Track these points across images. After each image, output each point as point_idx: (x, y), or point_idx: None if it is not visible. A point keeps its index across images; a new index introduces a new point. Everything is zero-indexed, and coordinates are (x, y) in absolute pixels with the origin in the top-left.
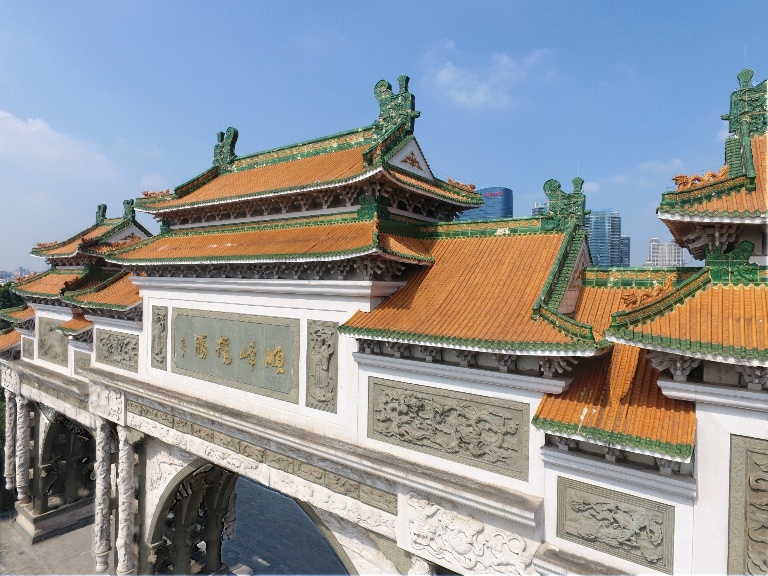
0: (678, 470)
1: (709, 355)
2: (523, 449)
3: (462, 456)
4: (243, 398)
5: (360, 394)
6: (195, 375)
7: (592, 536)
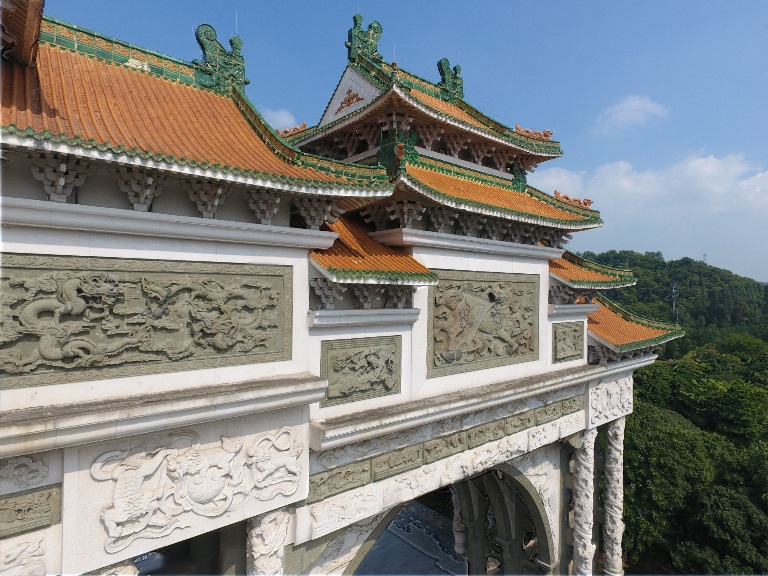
0: None
1: (446, 200)
2: (285, 322)
3: (200, 358)
4: None
5: None
6: None
7: (353, 388)
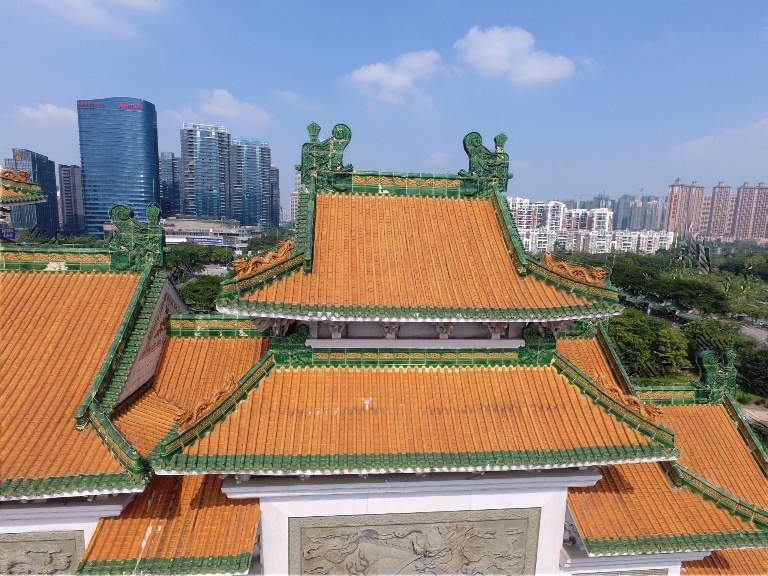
0: None
1: (261, 471)
2: None
3: None
4: None
5: None
6: None
7: None
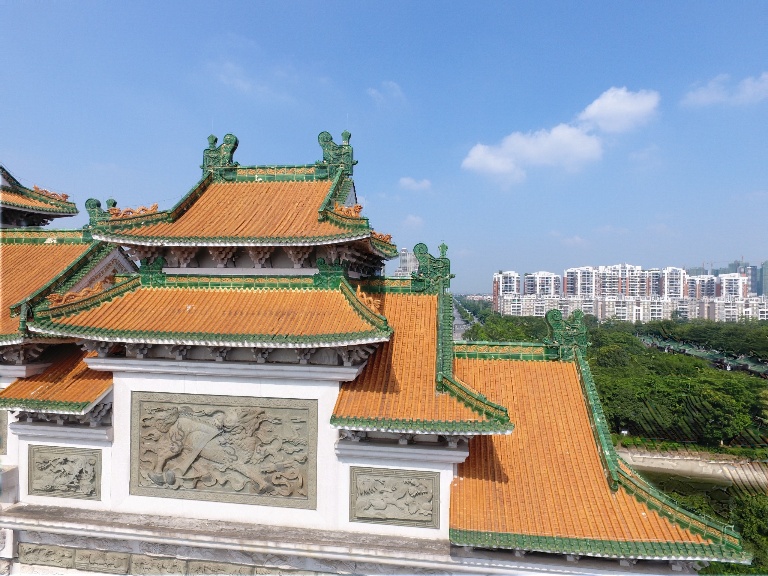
0: (110, 423)
1: (94, 336)
2: (4, 428)
3: None
4: None
5: None
6: None
7: (49, 487)
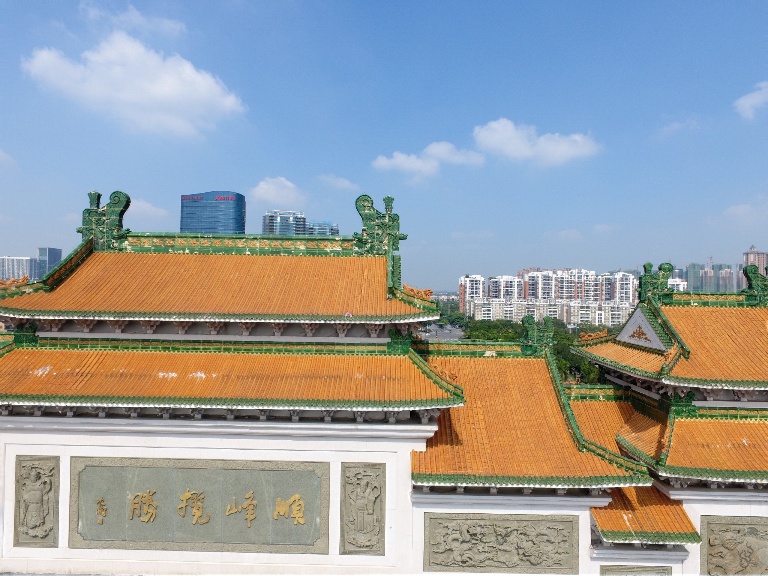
0: None
1: (710, 478)
2: (574, 551)
3: (522, 567)
4: (233, 561)
5: (415, 531)
6: (131, 546)
7: None
